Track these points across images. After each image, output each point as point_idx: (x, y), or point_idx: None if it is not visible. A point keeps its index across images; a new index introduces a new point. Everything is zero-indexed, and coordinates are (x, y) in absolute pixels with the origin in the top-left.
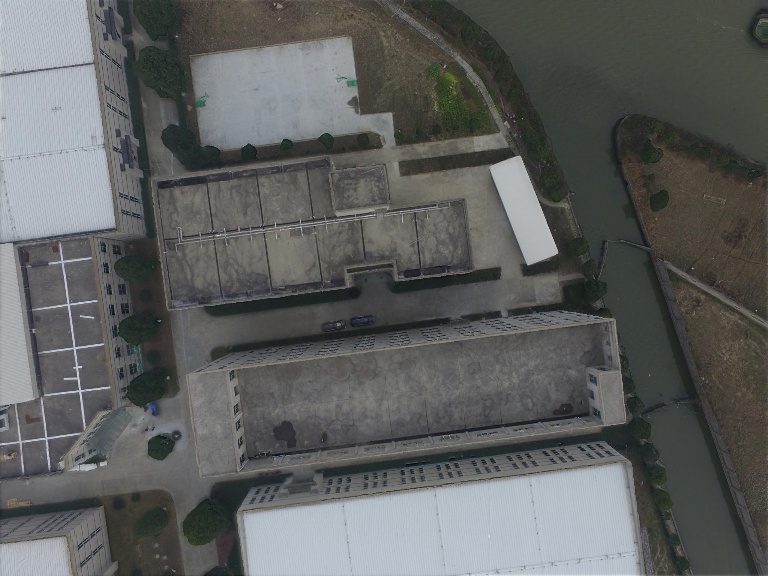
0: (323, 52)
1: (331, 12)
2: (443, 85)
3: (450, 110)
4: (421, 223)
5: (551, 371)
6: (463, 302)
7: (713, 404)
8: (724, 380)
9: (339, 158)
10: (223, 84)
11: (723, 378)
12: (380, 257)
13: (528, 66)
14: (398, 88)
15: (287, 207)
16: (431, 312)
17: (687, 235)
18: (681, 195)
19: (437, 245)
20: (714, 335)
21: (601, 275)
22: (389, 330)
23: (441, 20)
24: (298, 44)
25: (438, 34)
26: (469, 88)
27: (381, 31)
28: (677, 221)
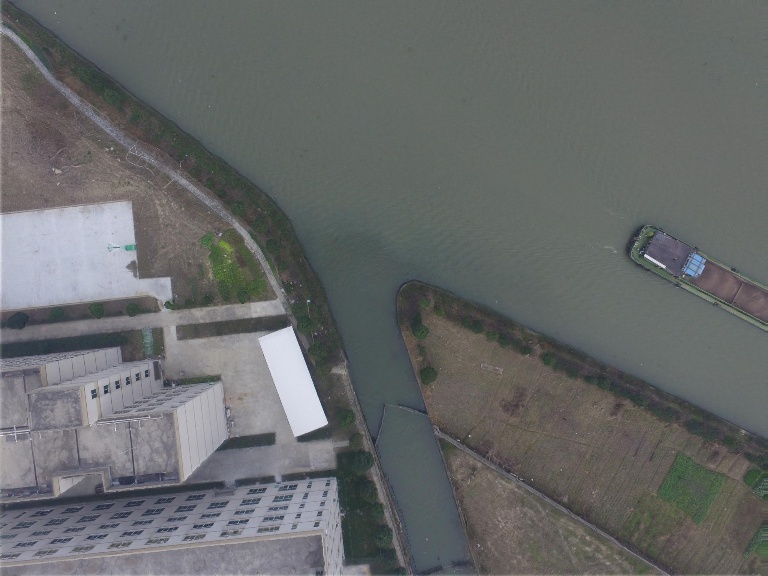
0: (103, 216)
1: (108, 179)
2: (217, 254)
3: (225, 278)
4: (135, 431)
5: (276, 570)
6: (238, 466)
7: (488, 571)
8: (499, 547)
9: (117, 321)
10: (4, 245)
11: (498, 545)
12: (94, 464)
13: (311, 230)
14: (172, 256)
15: (3, 413)
16: (206, 475)
17: (464, 403)
18: (458, 364)
19: (151, 453)
20: (490, 502)
21: (378, 440)
22: (163, 492)
23: (221, 186)
24: (79, 207)
25: (217, 201)
26: (245, 256)
27: (156, 199)
28: (453, 390)
